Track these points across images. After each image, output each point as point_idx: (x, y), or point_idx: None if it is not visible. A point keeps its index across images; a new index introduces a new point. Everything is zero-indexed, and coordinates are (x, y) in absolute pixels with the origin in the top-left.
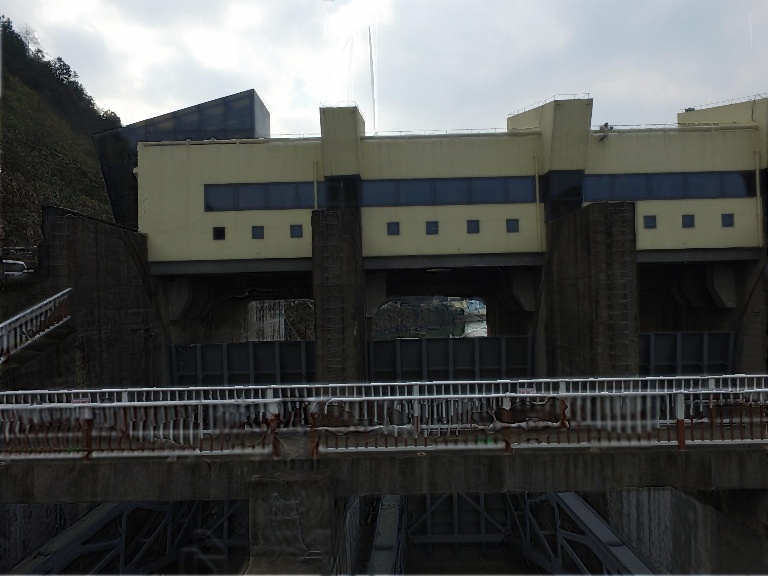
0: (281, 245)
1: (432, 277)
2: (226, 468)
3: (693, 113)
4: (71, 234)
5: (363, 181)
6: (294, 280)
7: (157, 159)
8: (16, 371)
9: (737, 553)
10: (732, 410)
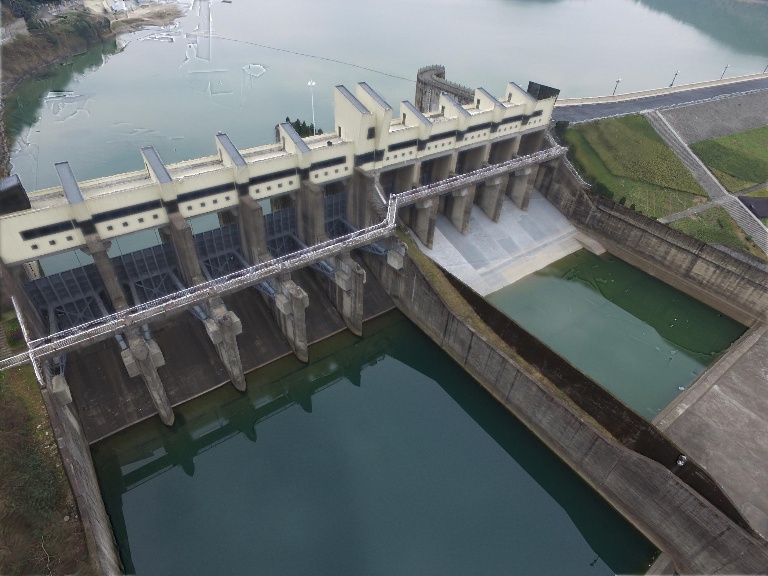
0: (64, 244)
1: None
2: (117, 331)
3: None
4: None
5: (92, 215)
6: None
7: None
8: None
9: (208, 308)
10: None
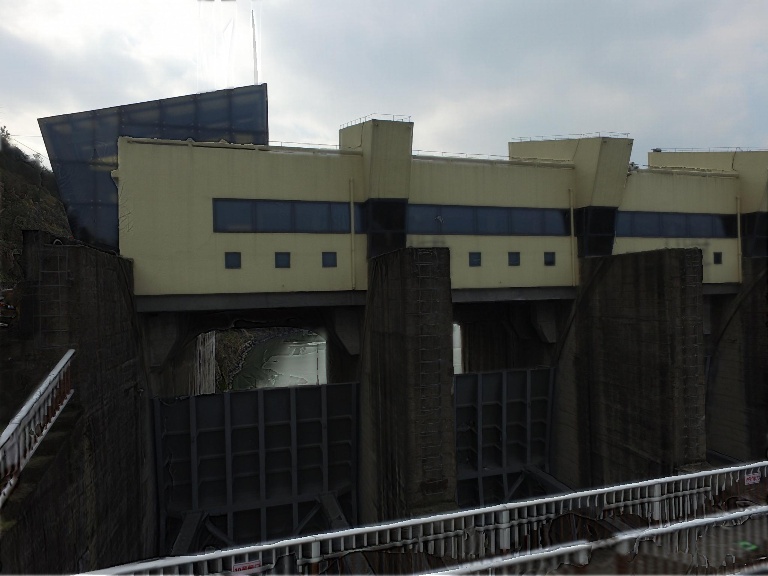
0: (311, 276)
1: None
2: None
3: (666, 154)
4: (72, 272)
5: None
6: (299, 310)
7: (146, 161)
8: (32, 497)
9: None
10: None
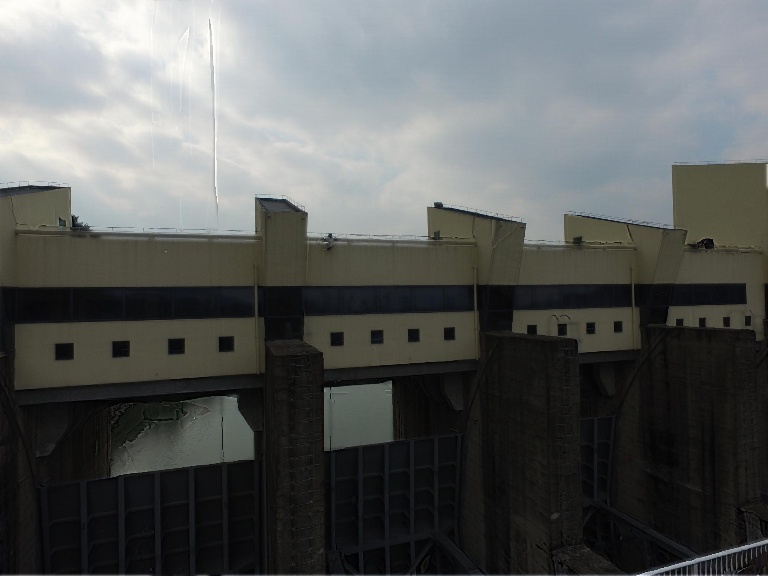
0: None
1: None
2: None
3: (437, 211)
4: None
5: (20, 289)
6: None
7: None
8: None
9: None
10: None
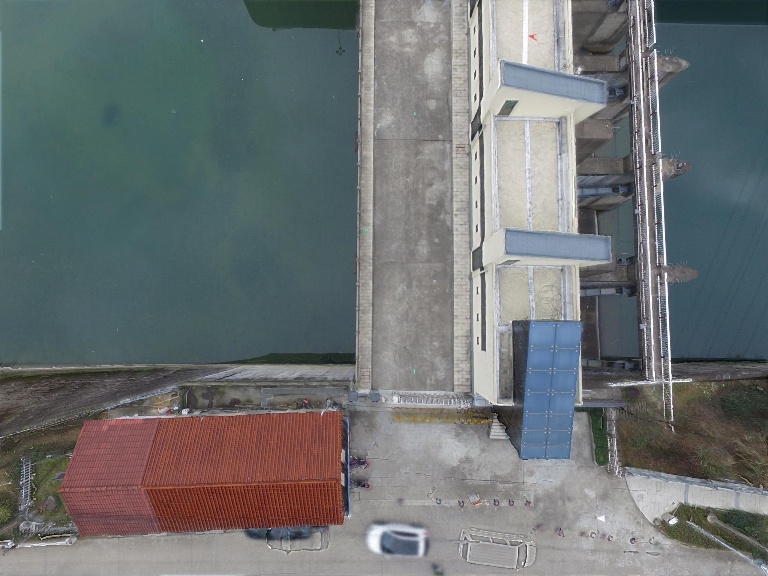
0: None
1: None
2: None
3: None
4: None
5: None
6: None
7: None
8: None
9: None
10: None
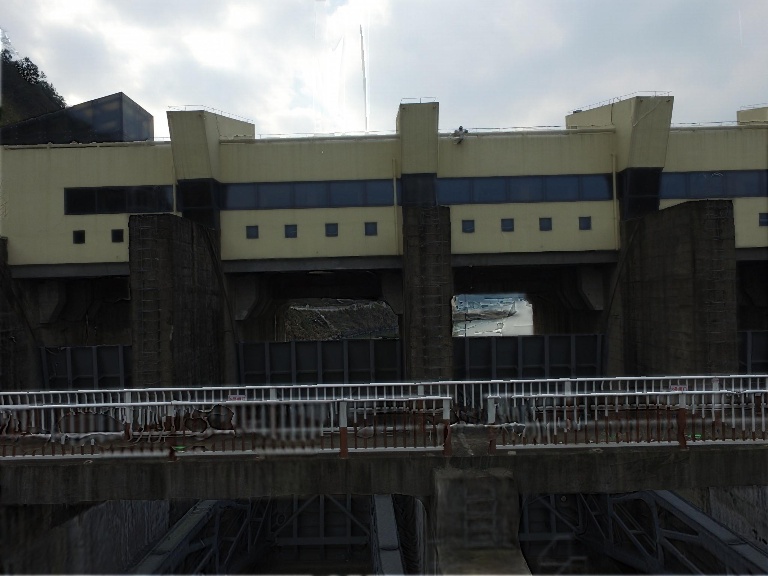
0: None
1: (318, 279)
2: None
3: (575, 115)
4: None
5: (222, 184)
6: None
7: (18, 162)
8: None
9: None
10: (396, 418)
